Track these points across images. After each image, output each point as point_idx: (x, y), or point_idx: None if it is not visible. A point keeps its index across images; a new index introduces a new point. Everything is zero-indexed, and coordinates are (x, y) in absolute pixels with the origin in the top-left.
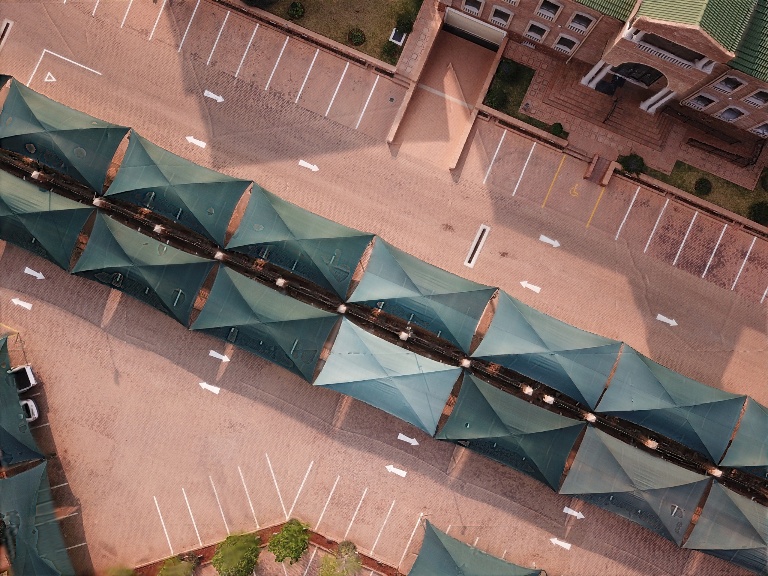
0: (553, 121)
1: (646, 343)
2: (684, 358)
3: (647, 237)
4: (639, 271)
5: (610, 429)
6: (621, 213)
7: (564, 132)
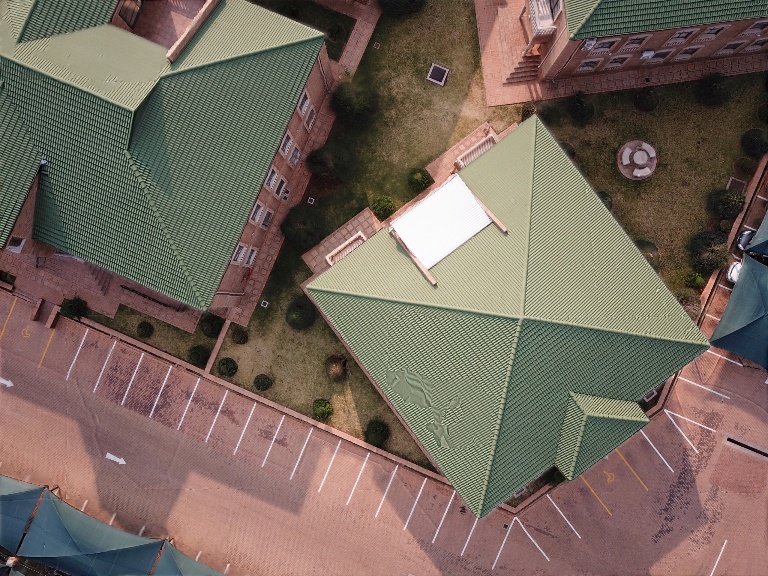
0: (1, 265)
1: (95, 481)
2: (131, 496)
3: (96, 377)
4: (89, 411)
5: (32, 572)
6: (71, 354)
7: (11, 276)
